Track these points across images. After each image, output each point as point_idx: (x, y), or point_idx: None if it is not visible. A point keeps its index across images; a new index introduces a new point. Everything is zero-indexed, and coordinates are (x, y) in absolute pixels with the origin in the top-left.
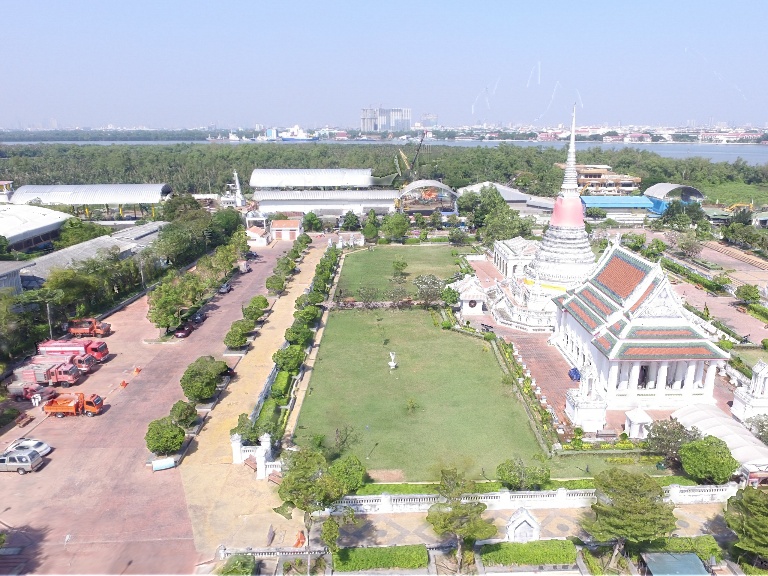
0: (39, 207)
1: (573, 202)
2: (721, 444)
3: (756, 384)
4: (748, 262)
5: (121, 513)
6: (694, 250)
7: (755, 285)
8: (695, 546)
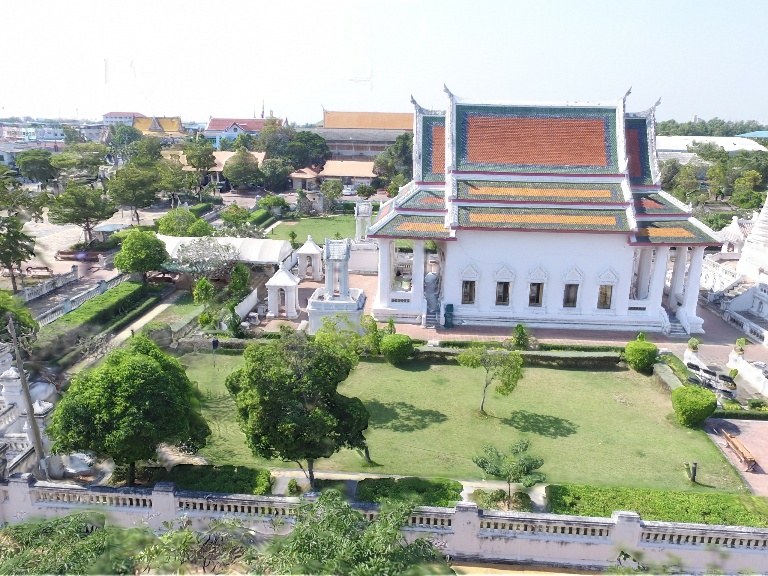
0: (751, 140)
1: None
2: None
3: None
4: None
5: (286, 201)
6: None
7: None
8: (120, 232)
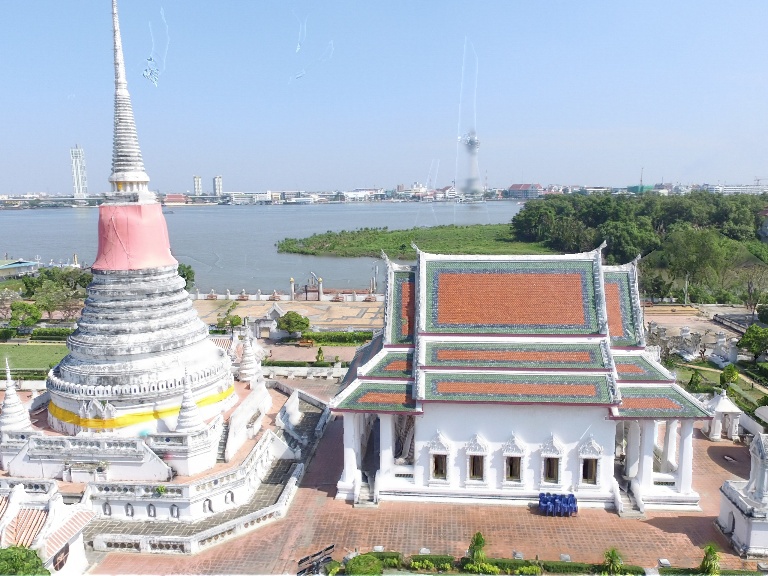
0: None
1: (157, 211)
2: None
3: None
4: None
5: None
6: (71, 307)
7: None
8: None
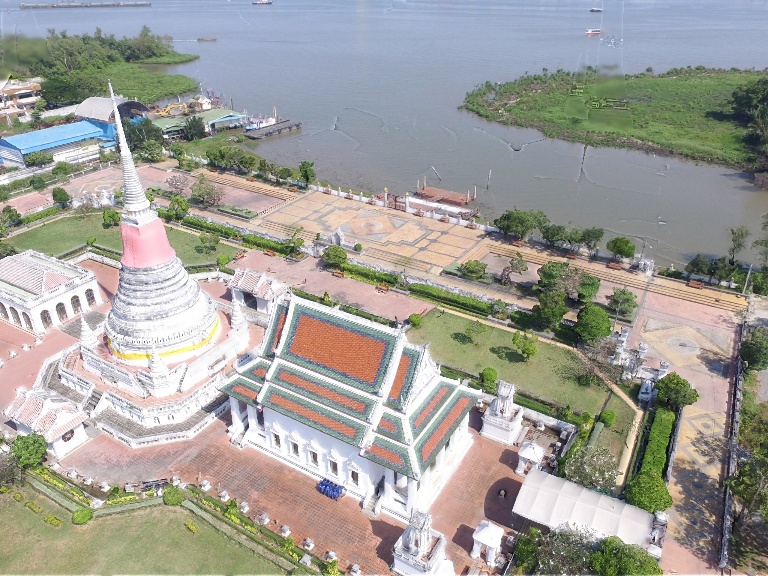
0: None
1: (154, 227)
2: (643, 553)
3: (506, 406)
4: (262, 193)
5: None
6: (215, 197)
7: (318, 234)
8: None
